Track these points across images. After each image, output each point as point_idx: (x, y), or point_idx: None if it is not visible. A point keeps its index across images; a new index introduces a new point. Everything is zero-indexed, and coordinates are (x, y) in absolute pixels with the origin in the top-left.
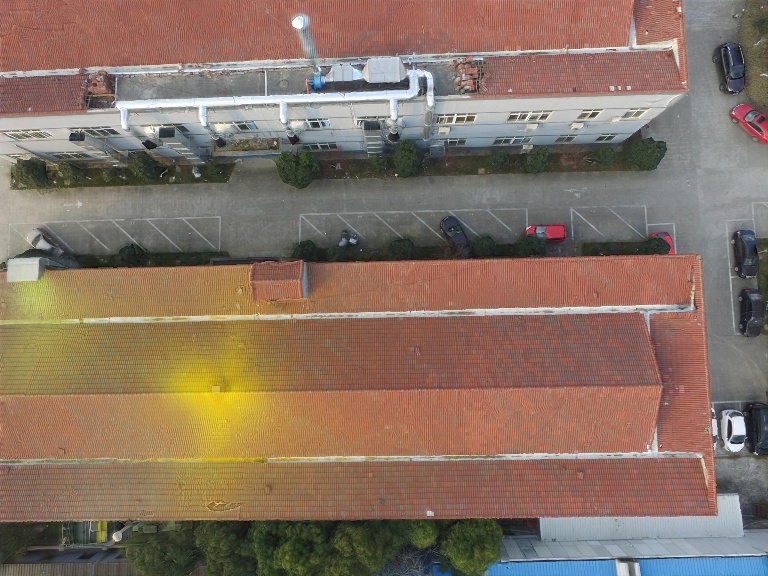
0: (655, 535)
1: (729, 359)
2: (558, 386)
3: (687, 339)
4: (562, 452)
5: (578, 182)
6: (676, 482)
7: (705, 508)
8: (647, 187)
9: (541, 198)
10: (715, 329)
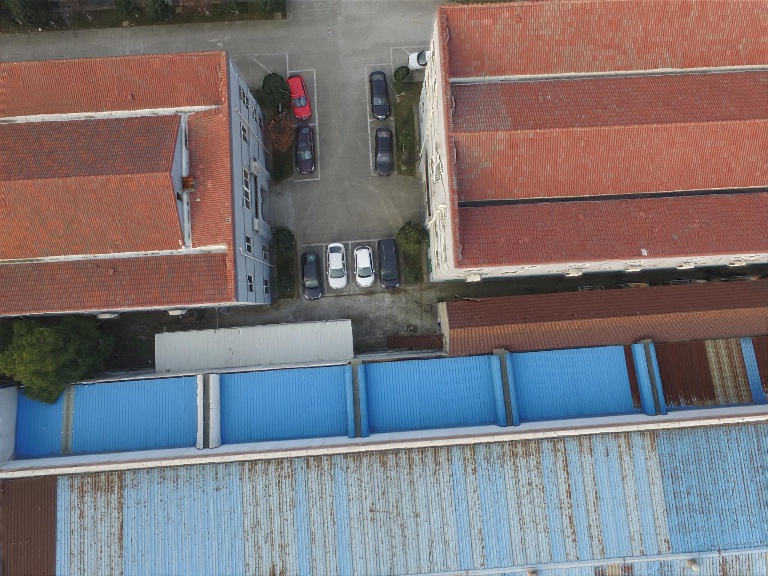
0: (267, 361)
1: (366, 199)
2: (67, 176)
3: (215, 135)
4: (97, 252)
5: (221, 32)
6: (203, 274)
7: (224, 295)
8: (289, 35)
9: (184, 48)
10: (353, 171)
